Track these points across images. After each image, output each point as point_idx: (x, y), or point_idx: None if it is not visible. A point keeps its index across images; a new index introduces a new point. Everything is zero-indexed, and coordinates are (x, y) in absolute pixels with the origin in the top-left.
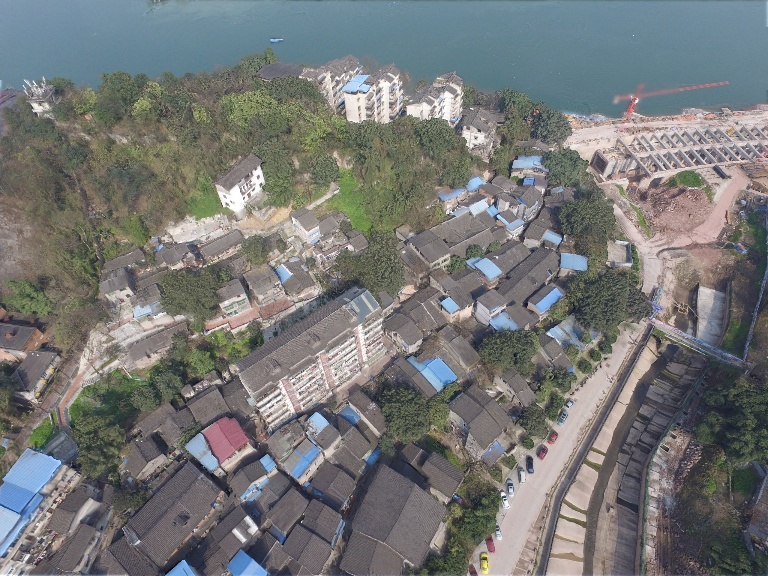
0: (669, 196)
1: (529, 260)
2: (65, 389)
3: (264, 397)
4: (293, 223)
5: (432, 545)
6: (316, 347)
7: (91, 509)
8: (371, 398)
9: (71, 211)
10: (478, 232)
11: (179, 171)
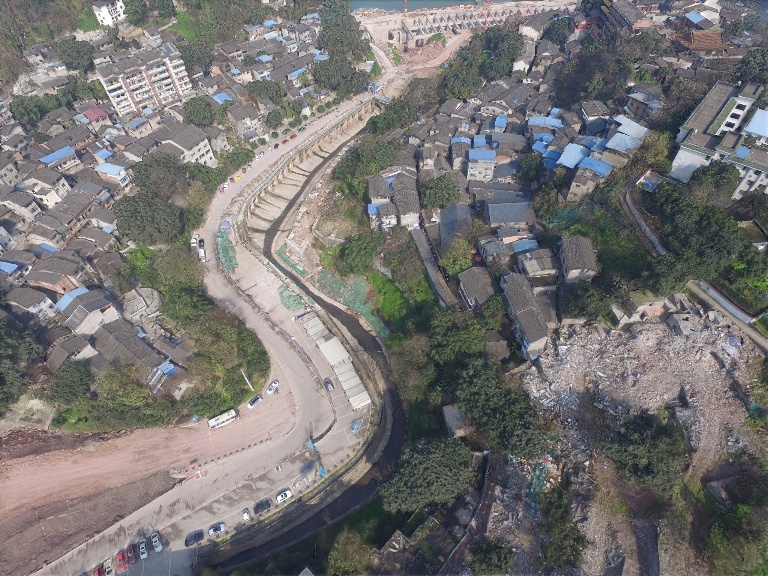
0: None
1: None
2: (6, 98)
3: (111, 85)
4: (146, 36)
5: (210, 166)
6: (140, 63)
7: (21, 134)
8: None
9: (4, 14)
10: None
11: (71, 3)
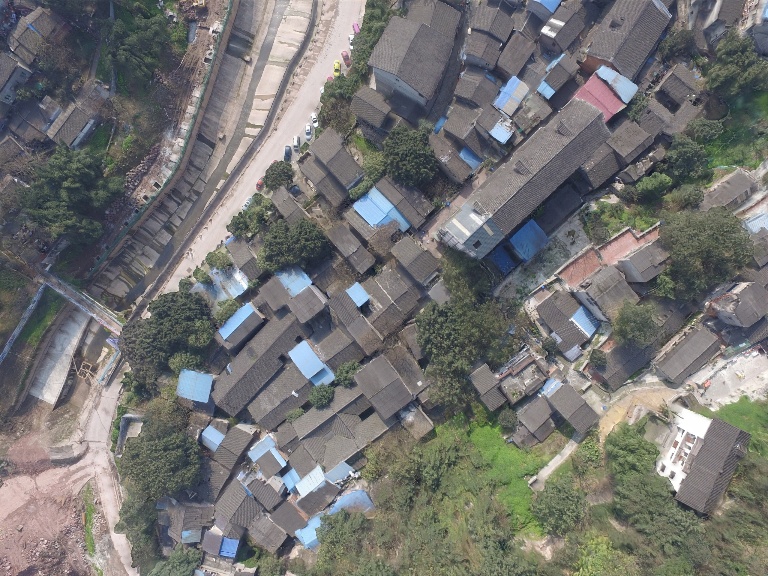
0: (36, 575)
1: (252, 390)
2: None
3: None
4: None
5: None
6: None
7: None
8: (447, 184)
9: None
10: (315, 434)
11: None
